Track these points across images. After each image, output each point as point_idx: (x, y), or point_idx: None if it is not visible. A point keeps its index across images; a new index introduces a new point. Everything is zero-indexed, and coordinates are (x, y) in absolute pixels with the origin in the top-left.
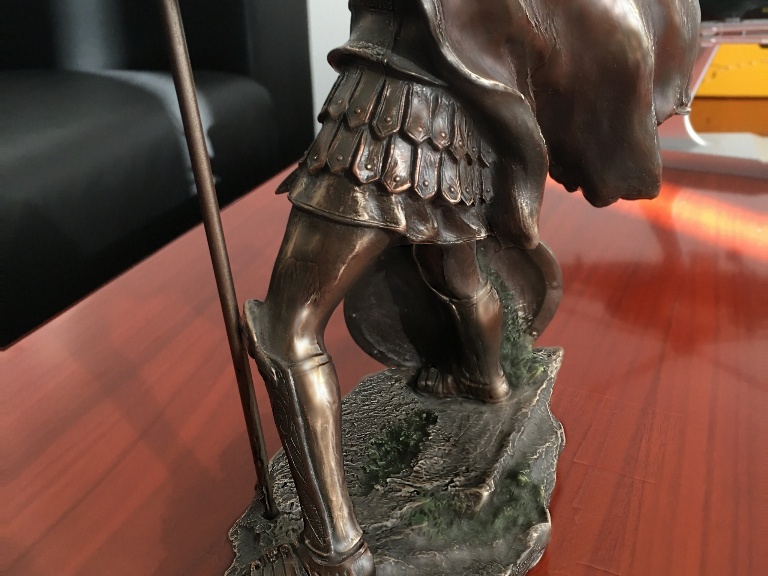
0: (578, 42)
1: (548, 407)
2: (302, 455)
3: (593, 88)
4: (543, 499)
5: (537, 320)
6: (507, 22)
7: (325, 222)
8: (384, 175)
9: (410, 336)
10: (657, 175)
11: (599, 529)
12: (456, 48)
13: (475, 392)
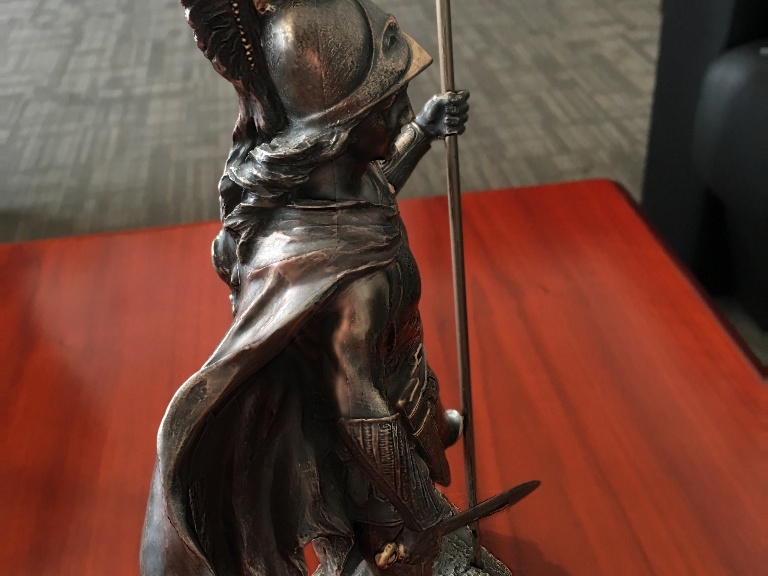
0: None
1: None
2: None
3: None
4: None
5: None
6: None
7: None
8: None
9: None
10: None
11: None
12: None
13: None
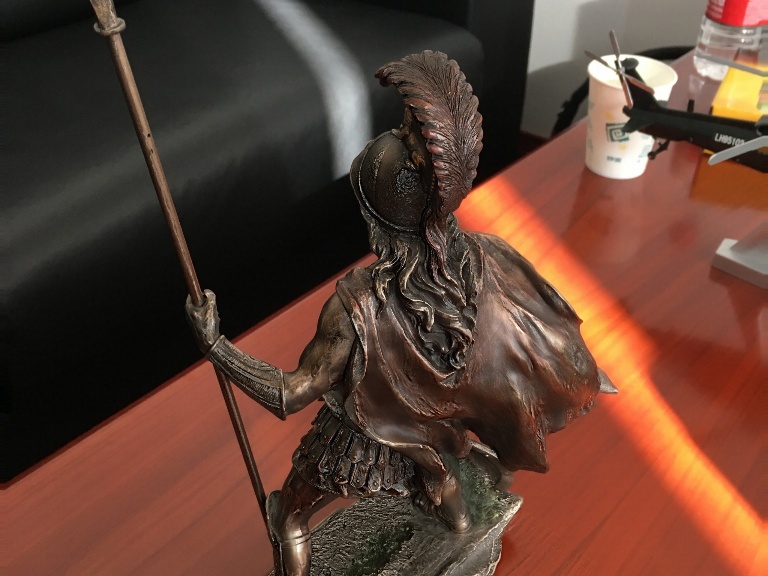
0: (477, 405)
1: (494, 543)
2: None
3: (493, 421)
4: None
5: (498, 486)
6: (409, 417)
7: None
8: (334, 473)
9: None
10: (543, 465)
11: None
12: (377, 426)
13: (446, 521)
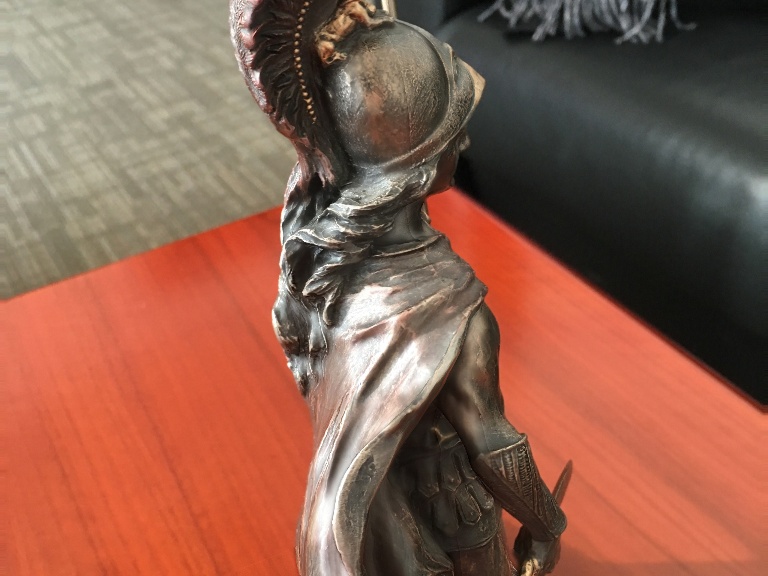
0: None
1: None
2: None
3: None
4: None
5: None
6: None
7: None
8: None
9: None
10: None
11: None
12: None
13: None
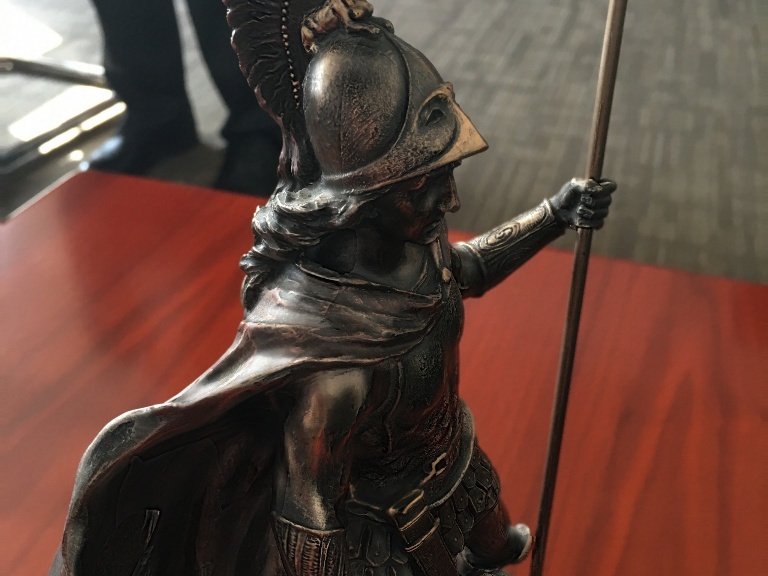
0: None
1: None
2: None
3: None
4: None
5: None
6: None
7: None
8: None
9: None
10: None
11: None
12: None
13: None
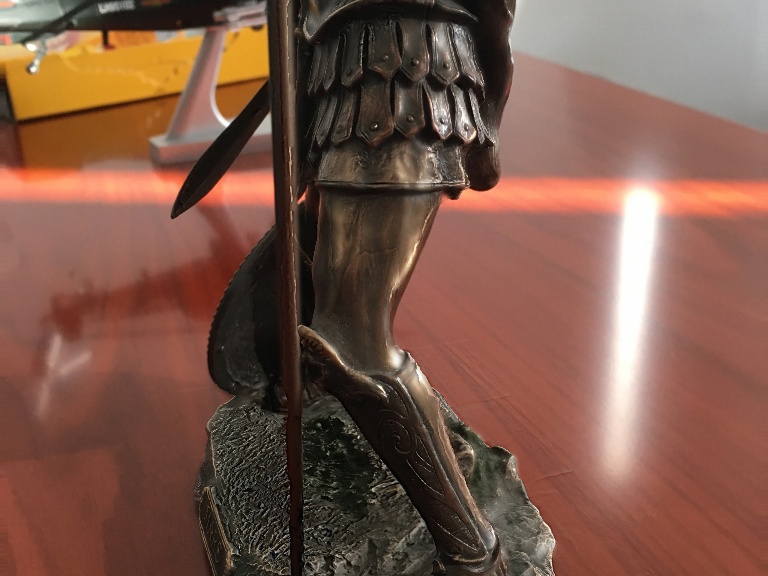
0: None
1: None
2: (434, 466)
3: None
4: (482, 442)
5: None
6: None
7: (399, 197)
8: (455, 126)
9: (260, 354)
10: None
11: (520, 448)
12: None
13: None
